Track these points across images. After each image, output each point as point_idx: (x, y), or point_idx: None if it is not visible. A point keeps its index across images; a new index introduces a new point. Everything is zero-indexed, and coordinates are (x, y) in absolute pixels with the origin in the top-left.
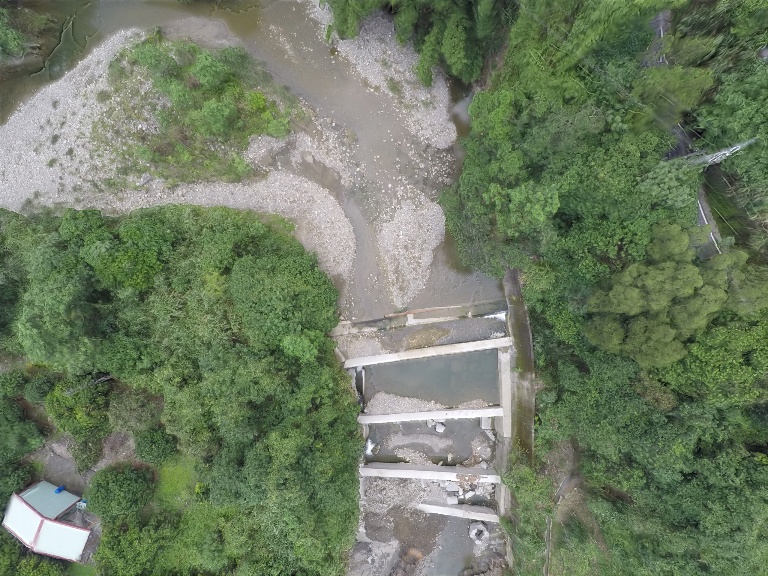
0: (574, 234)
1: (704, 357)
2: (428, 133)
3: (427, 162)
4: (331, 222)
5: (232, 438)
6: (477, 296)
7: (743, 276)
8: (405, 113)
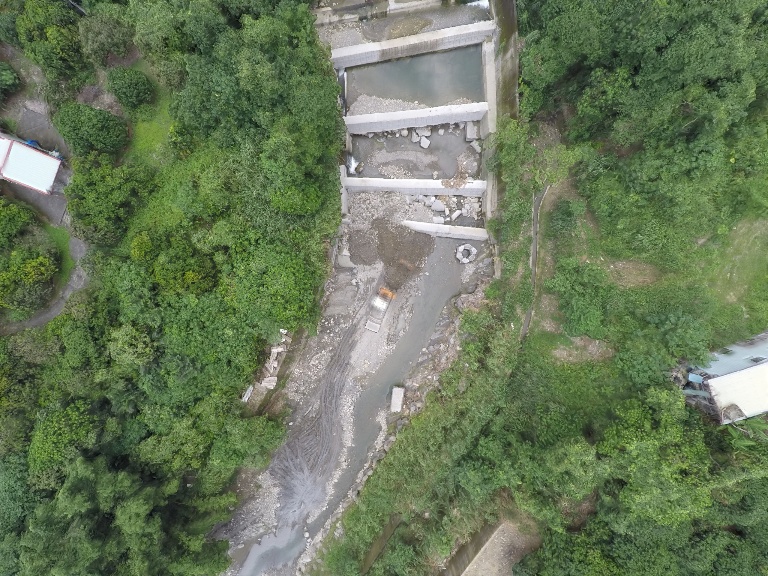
0: None
1: None
2: None
3: None
4: None
5: (203, 31)
6: None
7: None
8: None
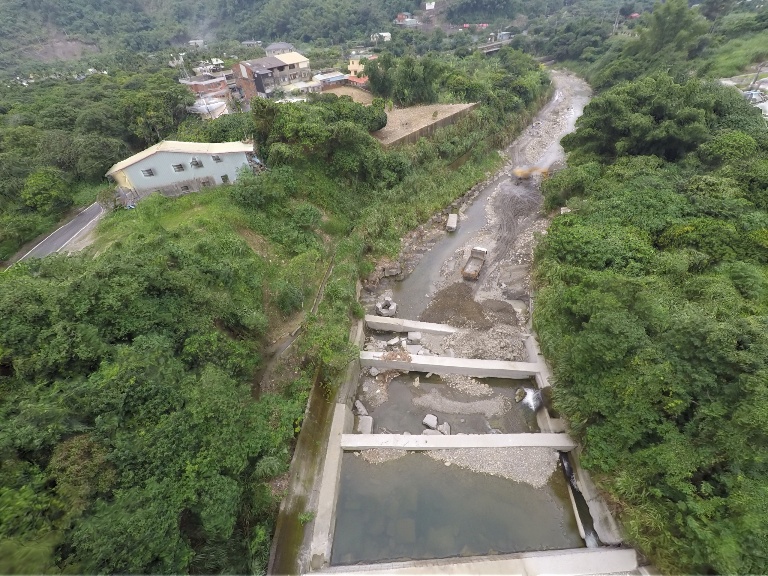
0: None
1: None
2: None
3: None
4: None
5: None
6: None
7: None
8: None
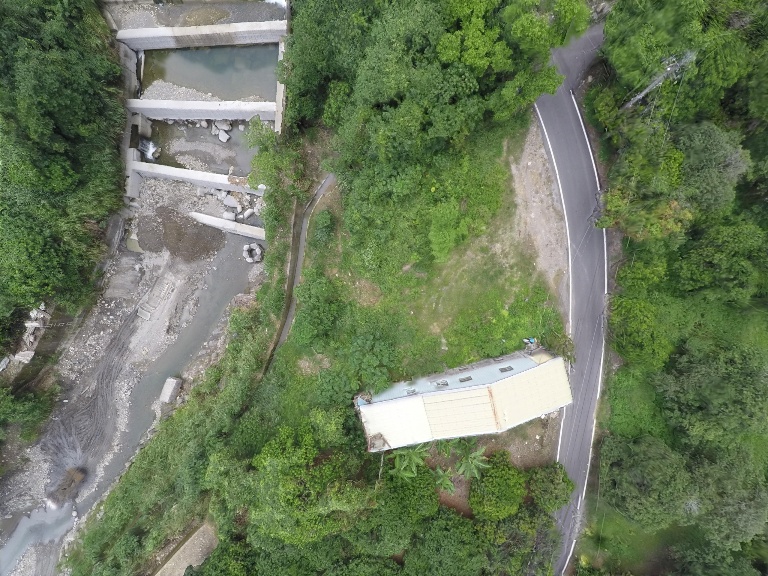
0: None
1: None
2: None
3: None
4: None
5: None
6: None
7: None
8: None
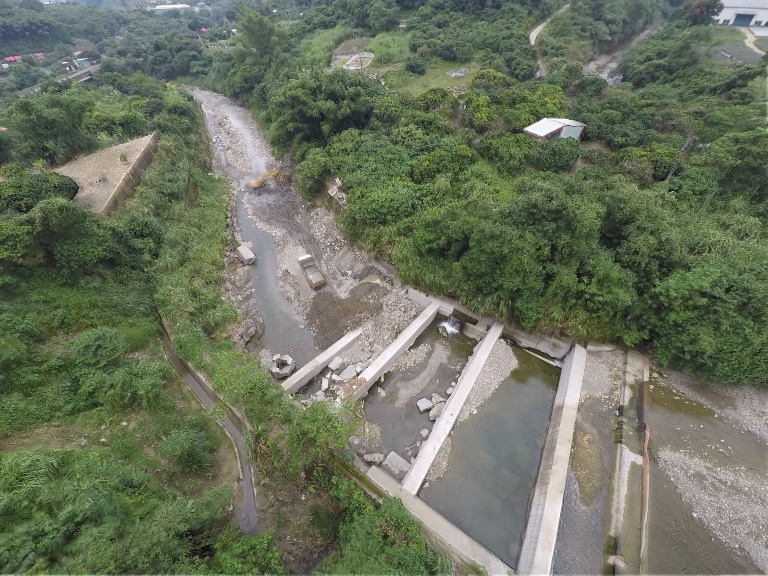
0: None
1: None
2: None
3: None
4: None
5: None
6: None
7: None
8: None
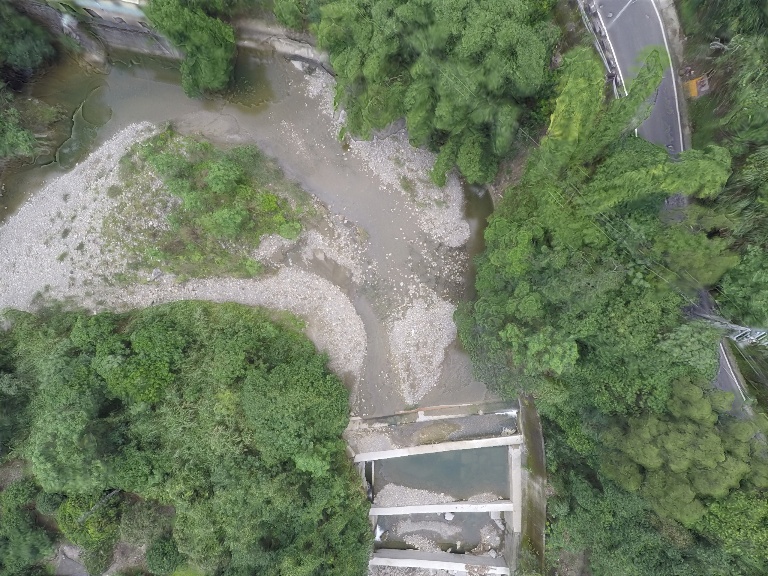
0: (591, 368)
1: (724, 518)
2: (441, 232)
3: (439, 261)
4: (342, 319)
5: (244, 562)
6: (488, 394)
7: (766, 449)
8: (418, 211)
